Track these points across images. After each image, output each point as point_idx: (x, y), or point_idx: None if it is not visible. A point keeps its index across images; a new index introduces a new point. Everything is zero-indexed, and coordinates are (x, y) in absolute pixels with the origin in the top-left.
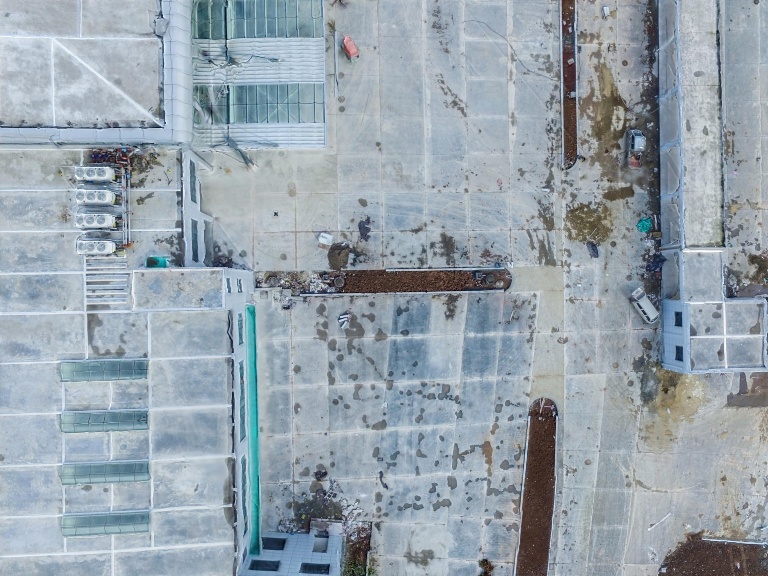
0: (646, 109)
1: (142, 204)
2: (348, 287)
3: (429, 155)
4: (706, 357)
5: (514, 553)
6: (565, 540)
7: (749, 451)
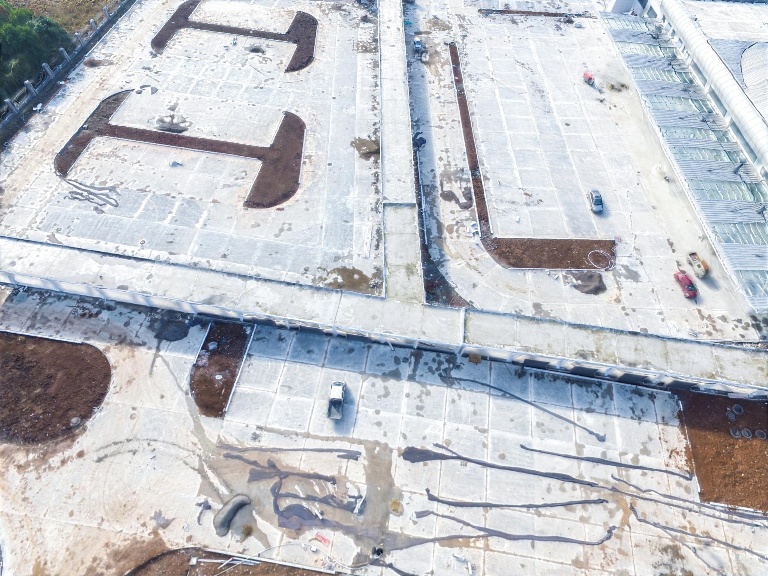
0: (408, 60)
1: None
2: None
3: (532, 48)
4: None
5: None
6: None
7: None
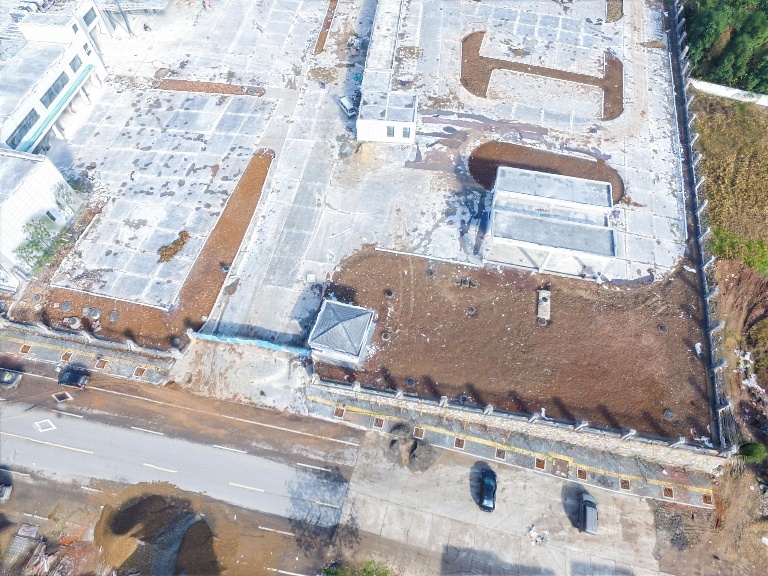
0: None
1: (56, 11)
2: (161, 87)
3: (235, 43)
4: (372, 114)
5: (210, 229)
6: (259, 236)
7: (421, 195)
